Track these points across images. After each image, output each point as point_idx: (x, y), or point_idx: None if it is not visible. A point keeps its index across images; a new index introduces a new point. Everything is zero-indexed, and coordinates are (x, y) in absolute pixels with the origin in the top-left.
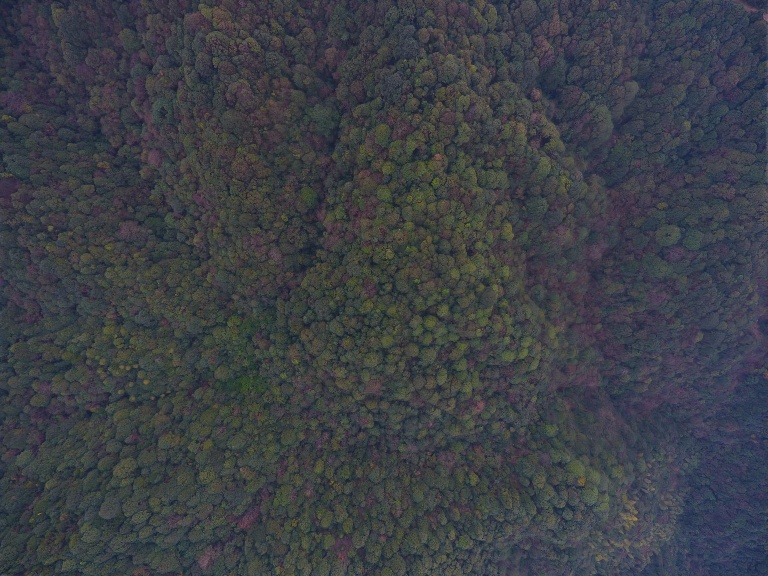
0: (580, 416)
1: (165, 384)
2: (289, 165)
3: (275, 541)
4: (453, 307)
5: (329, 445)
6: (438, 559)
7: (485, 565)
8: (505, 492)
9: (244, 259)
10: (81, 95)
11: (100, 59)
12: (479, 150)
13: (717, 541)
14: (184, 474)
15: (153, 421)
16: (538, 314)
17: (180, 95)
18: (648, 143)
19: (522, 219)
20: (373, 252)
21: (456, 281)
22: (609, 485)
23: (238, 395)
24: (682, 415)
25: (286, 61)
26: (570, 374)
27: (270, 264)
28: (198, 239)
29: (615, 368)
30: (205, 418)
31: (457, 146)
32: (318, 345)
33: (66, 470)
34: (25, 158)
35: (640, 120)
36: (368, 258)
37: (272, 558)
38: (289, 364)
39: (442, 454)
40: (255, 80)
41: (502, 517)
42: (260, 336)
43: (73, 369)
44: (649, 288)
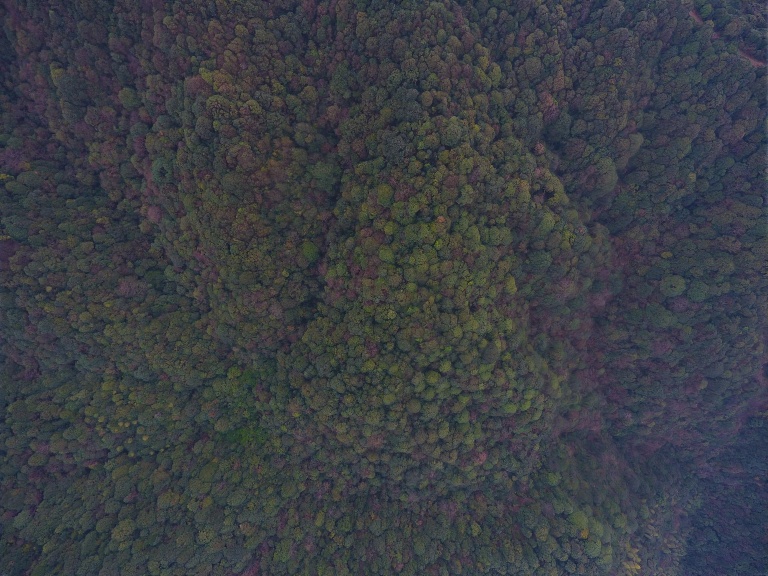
0: (583, 462)
1: (164, 438)
2: (290, 221)
3: None
4: (455, 363)
5: (330, 496)
6: None
7: None
8: (507, 544)
9: (244, 314)
10: (80, 150)
11: (99, 117)
12: (482, 209)
13: None
14: (183, 535)
15: (152, 478)
16: (541, 365)
17: (180, 157)
18: (653, 193)
19: (525, 271)
20: (375, 311)
21: (459, 339)
22: (612, 536)
23: (238, 447)
24: (685, 456)
25: (287, 120)
26: (573, 420)
27: (271, 319)
28: (198, 293)
29: (618, 412)
30: (205, 475)
31: (460, 206)
32: (319, 401)
33: (64, 532)
34: (23, 219)
35: (645, 171)
36: (370, 317)
37: None
38: (290, 417)
39: (444, 503)
40: (256, 141)
41: (504, 570)
42: (260, 388)
43: (71, 427)
44: (653, 336)
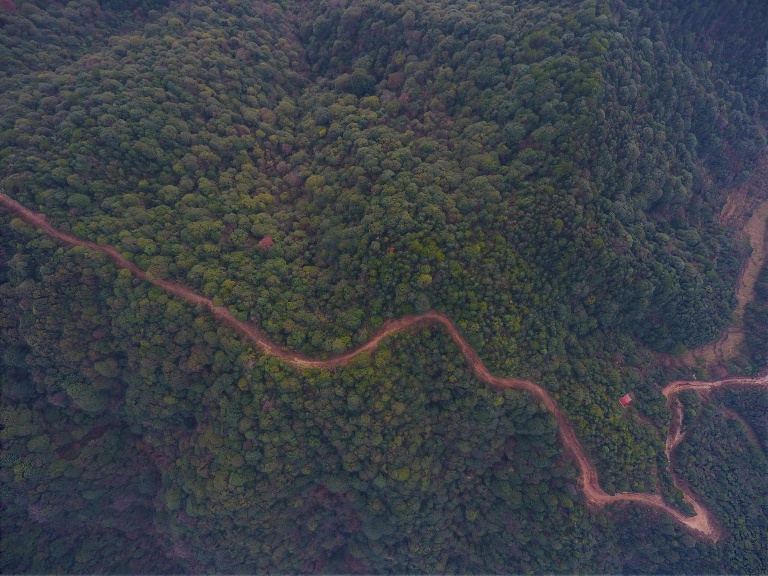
0: None
1: None
2: None
3: None
4: None
5: None
6: None
7: None
8: None
9: None
10: None
11: None
12: None
13: None
14: None
15: None
16: (47, 575)
17: None
18: None
19: None
20: None
21: None
22: None
23: None
24: None
25: None
26: None
27: None
28: None
29: None
30: None
31: None
32: None
33: None
34: None
35: (131, 390)
36: None
37: None
38: None
39: None
40: None
41: None
42: None
43: None
44: None
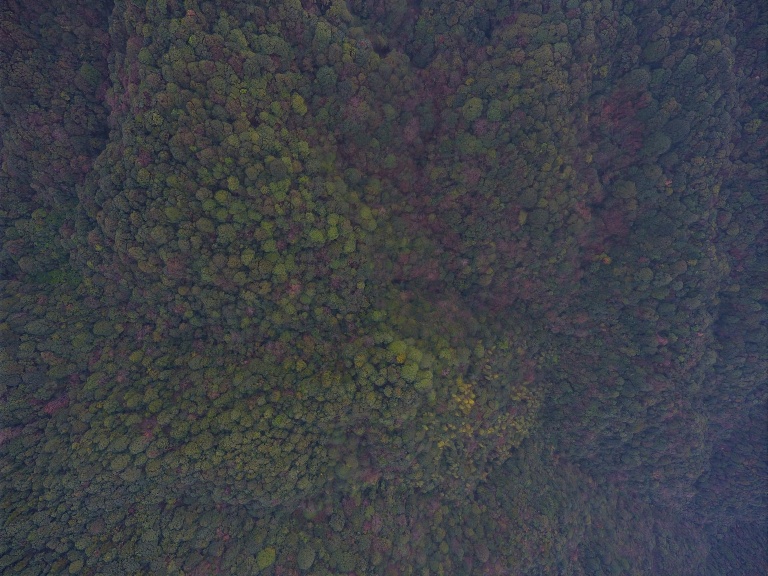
0: (417, 306)
1: None
2: (60, 39)
3: (76, 420)
4: (244, 180)
5: (150, 337)
6: (248, 434)
7: (312, 447)
8: (326, 373)
9: (29, 141)
10: None
11: None
12: (244, 11)
13: (578, 433)
14: None
15: None
16: (348, 194)
17: None
18: (446, 15)
19: (318, 94)
20: (144, 119)
21: (237, 149)
22: (434, 364)
23: (46, 287)
24: (537, 311)
25: None
26: (403, 264)
27: (57, 145)
28: None
29: (456, 260)
30: None
31: (216, 5)
32: (108, 224)
33: None
34: None
35: None
36: (142, 127)
37: (71, 436)
38: (94, 252)
39: (269, 343)
40: None
41: (321, 396)
42: (66, 227)
43: None
44: (466, 168)
